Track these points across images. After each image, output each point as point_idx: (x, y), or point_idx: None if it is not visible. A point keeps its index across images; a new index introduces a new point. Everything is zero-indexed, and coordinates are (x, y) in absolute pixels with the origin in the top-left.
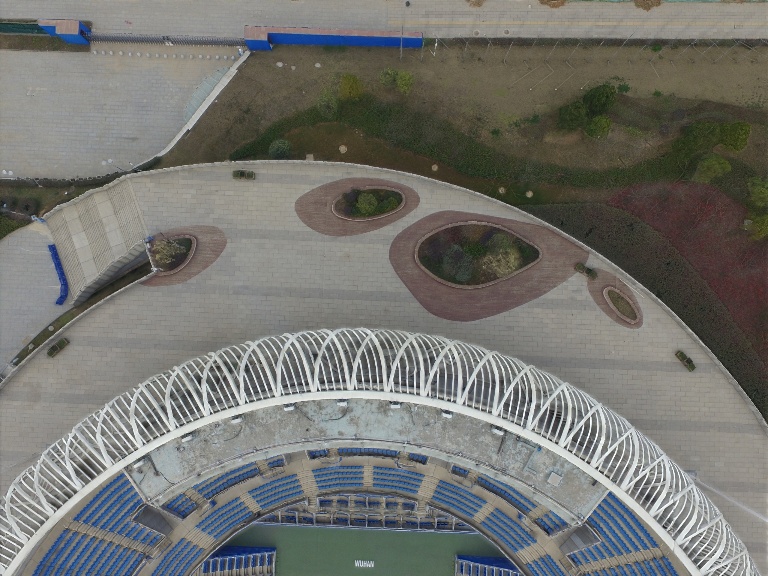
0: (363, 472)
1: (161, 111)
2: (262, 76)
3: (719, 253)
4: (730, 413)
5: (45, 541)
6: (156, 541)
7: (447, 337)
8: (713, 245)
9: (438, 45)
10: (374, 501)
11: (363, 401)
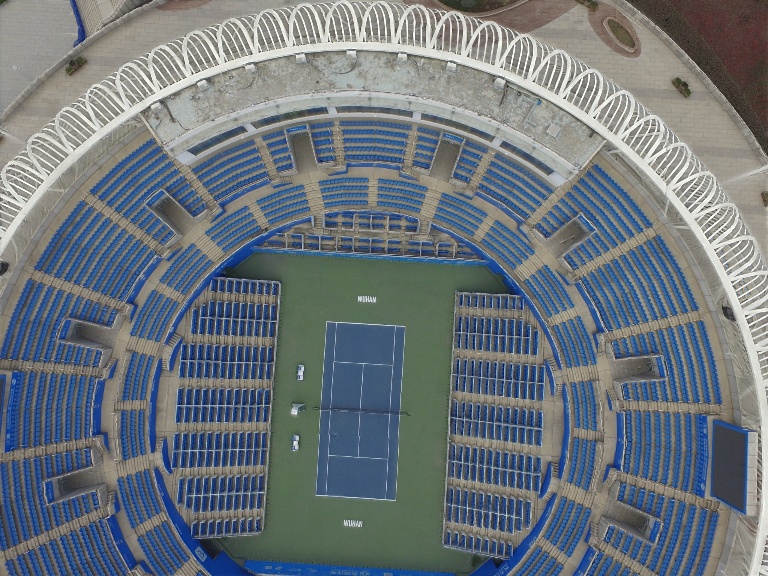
0: (368, 188)
1: None
2: None
3: (716, 10)
4: (723, 138)
5: (62, 211)
6: (167, 239)
7: None
8: (710, 2)
9: None
10: (378, 223)
11: (371, 56)
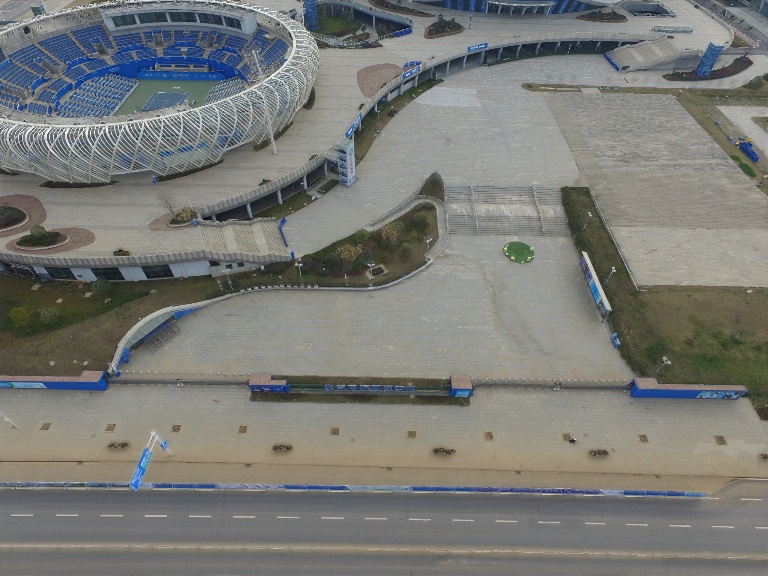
0: None
1: (202, 333)
2: (101, 346)
3: None
4: None
5: None
6: None
7: (33, 189)
8: None
9: None
10: None
11: None
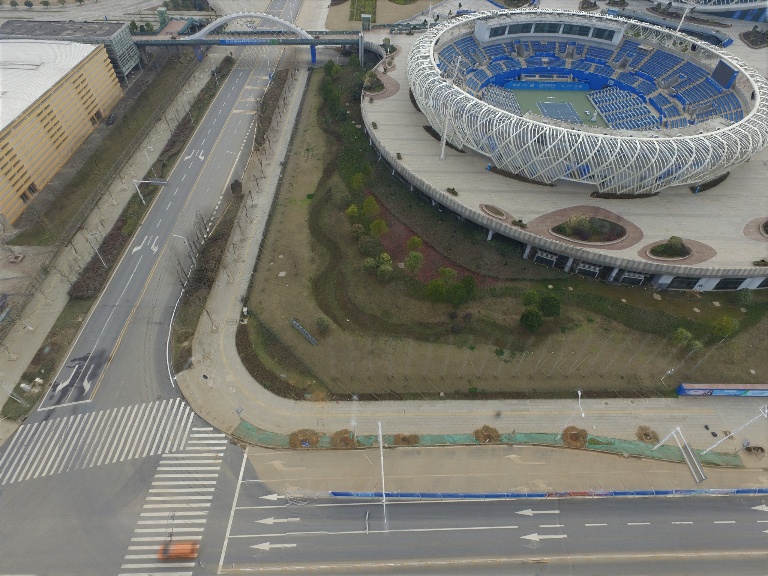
0: None
1: None
2: None
3: None
4: (424, 176)
5: None
6: None
7: (589, 200)
8: None
9: (662, 391)
10: None
11: None
